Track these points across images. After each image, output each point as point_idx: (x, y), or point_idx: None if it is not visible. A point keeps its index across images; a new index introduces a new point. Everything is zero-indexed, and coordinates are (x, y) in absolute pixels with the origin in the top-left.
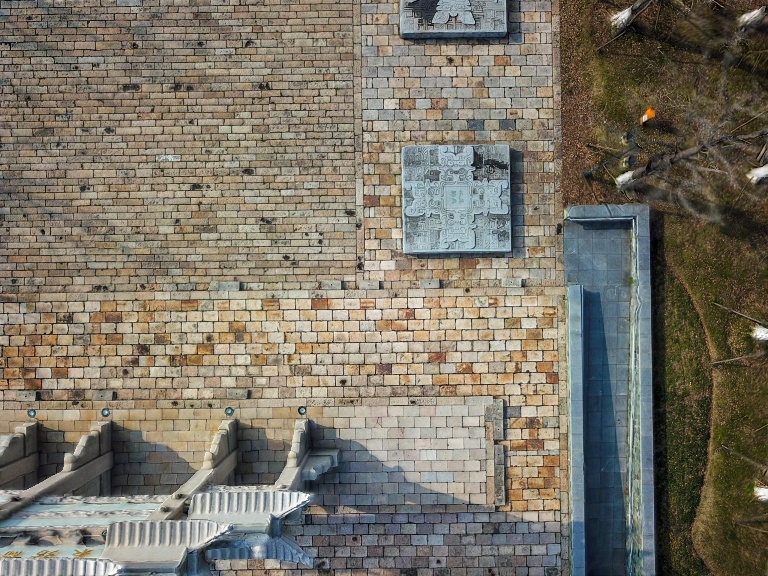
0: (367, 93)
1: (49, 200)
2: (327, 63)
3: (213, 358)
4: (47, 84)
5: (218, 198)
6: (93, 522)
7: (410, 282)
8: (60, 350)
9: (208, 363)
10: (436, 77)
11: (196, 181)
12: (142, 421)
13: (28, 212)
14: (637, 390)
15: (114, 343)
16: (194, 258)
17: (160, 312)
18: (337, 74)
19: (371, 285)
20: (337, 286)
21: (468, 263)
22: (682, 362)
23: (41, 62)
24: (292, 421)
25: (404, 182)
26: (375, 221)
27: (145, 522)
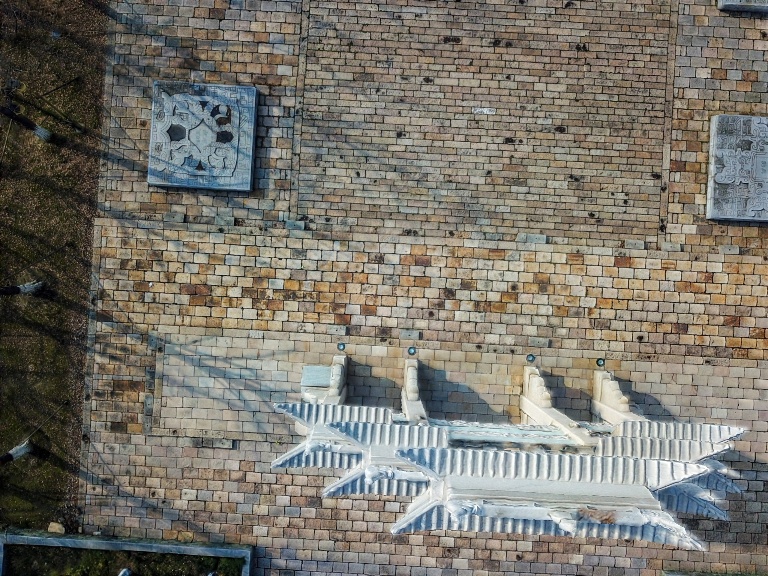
0: (680, 61)
1: (366, 143)
2: (644, 29)
3: (516, 306)
4: (370, 30)
5: (529, 153)
6: (523, 441)
7: (709, 247)
8: (370, 289)
9: (511, 311)
10: (749, 50)
11: (509, 135)
12: (447, 362)
13: (345, 154)
14: None
15: (422, 285)
16: (503, 209)
17: (468, 259)
18: (653, 40)
19: (673, 247)
20: (640, 246)
21: (767, 232)
22: None
23: (365, 8)
24: (590, 372)
25: (715, 149)
26: (680, 186)
27: (634, 438)
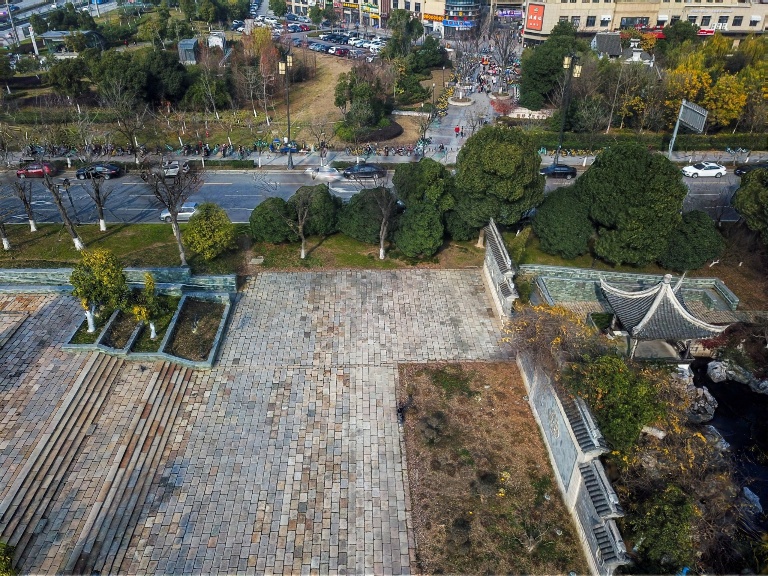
0: None
1: None
2: None
3: None
4: None
5: None
6: None
7: None
8: None
9: None
10: None
11: None
12: None
13: None
14: (3, 275)
15: None
16: None
17: None
18: None
19: None
20: None
21: None
22: (3, 266)
23: None
24: None
25: None
26: None
27: None
